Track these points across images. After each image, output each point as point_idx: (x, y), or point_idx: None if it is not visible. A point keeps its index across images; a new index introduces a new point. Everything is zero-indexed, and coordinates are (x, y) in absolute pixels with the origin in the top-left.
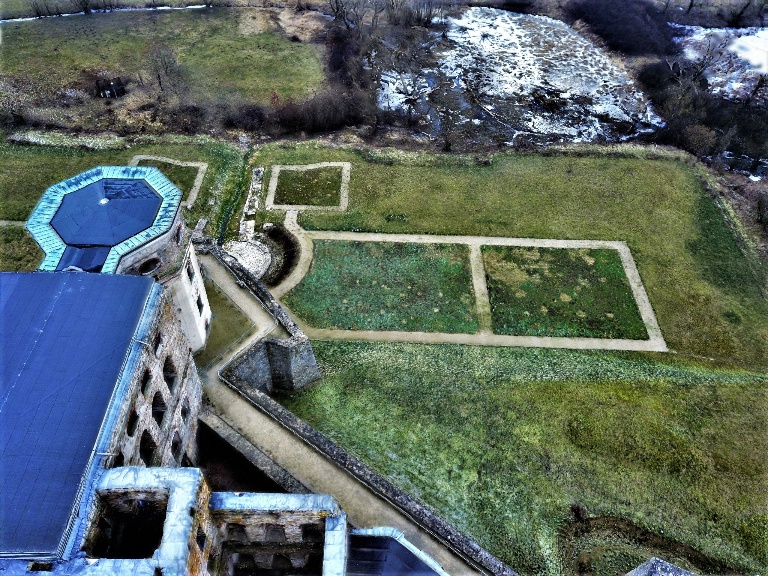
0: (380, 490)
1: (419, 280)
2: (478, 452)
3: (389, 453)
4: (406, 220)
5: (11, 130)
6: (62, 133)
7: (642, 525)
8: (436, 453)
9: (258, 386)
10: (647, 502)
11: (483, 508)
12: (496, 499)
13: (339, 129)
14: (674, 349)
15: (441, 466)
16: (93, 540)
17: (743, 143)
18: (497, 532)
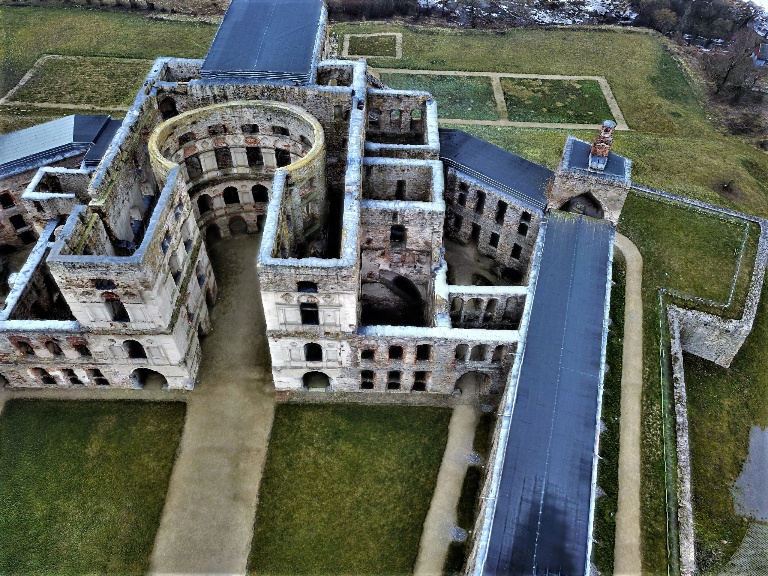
0: None
1: (456, 94)
2: None
3: None
4: (445, 64)
5: (146, 13)
6: (184, 15)
7: None
8: None
9: None
10: None
11: None
12: None
13: (389, 18)
14: (633, 129)
15: None
16: None
17: (700, 28)
18: None
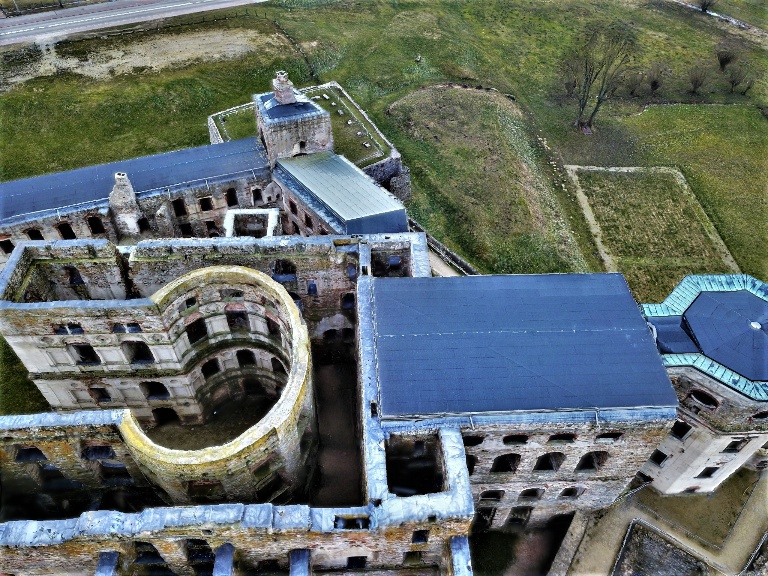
0: None
1: None
2: None
3: None
4: None
5: None
6: None
7: None
8: None
9: (647, 574)
10: None
11: None
12: None
13: None
14: None
15: None
16: (404, 442)
17: None
18: None
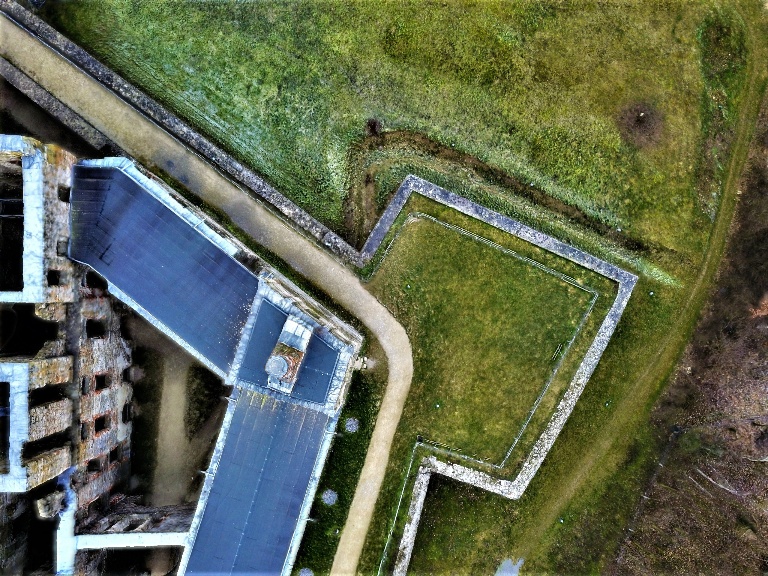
0: (148, 113)
1: None
2: (281, 64)
3: (186, 67)
4: None
5: None
6: None
7: (436, 138)
8: (236, 66)
9: None
10: (447, 116)
11: (278, 124)
12: (292, 115)
13: None
14: None
15: (240, 80)
16: None
17: None
18: (288, 147)
